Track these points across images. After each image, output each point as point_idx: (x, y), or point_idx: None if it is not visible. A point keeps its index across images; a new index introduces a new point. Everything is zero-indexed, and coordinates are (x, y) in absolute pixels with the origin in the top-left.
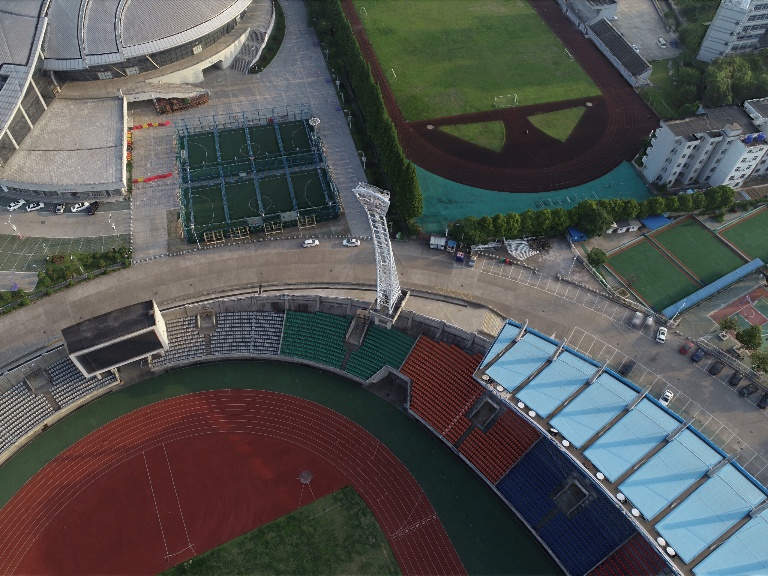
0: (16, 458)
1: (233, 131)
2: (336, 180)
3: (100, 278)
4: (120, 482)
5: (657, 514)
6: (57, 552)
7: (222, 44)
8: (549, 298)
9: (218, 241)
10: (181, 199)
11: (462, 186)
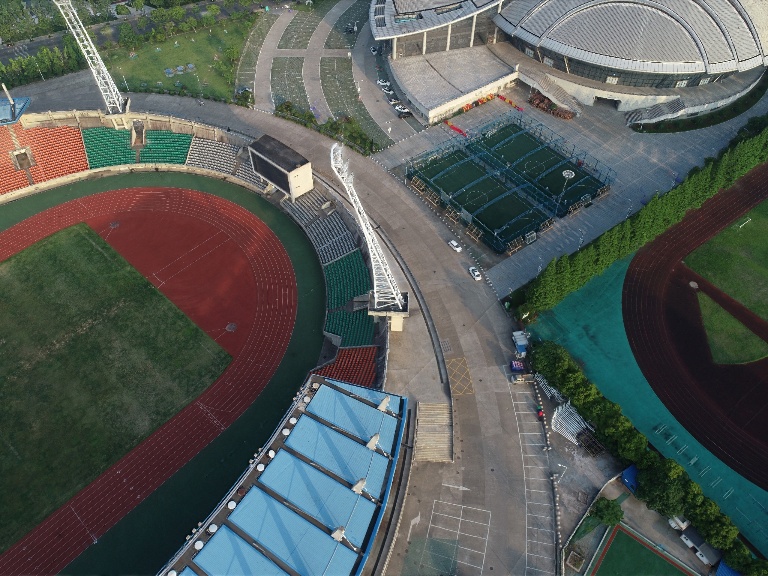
0: (200, 177)
1: (547, 148)
2: (545, 236)
3: (347, 148)
4: (198, 229)
5: (203, 570)
6: (146, 223)
7: (638, 91)
8: (515, 472)
9: (419, 190)
10: (442, 150)
11: (625, 341)
